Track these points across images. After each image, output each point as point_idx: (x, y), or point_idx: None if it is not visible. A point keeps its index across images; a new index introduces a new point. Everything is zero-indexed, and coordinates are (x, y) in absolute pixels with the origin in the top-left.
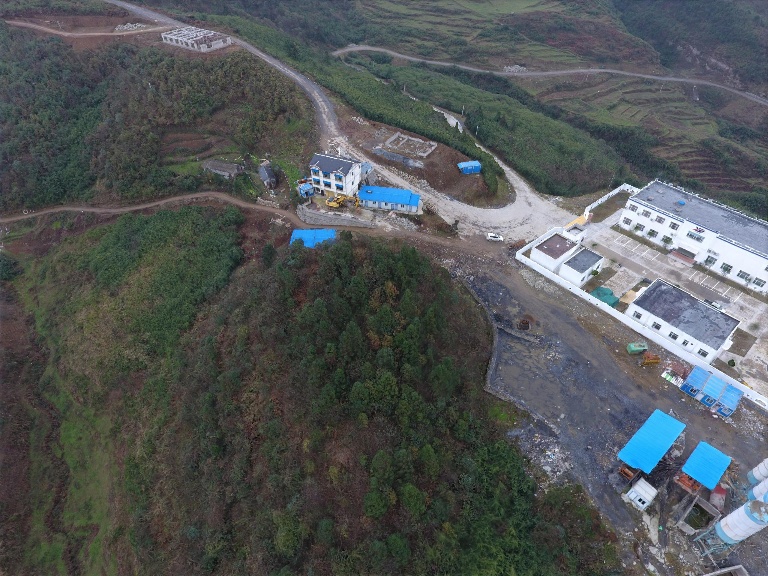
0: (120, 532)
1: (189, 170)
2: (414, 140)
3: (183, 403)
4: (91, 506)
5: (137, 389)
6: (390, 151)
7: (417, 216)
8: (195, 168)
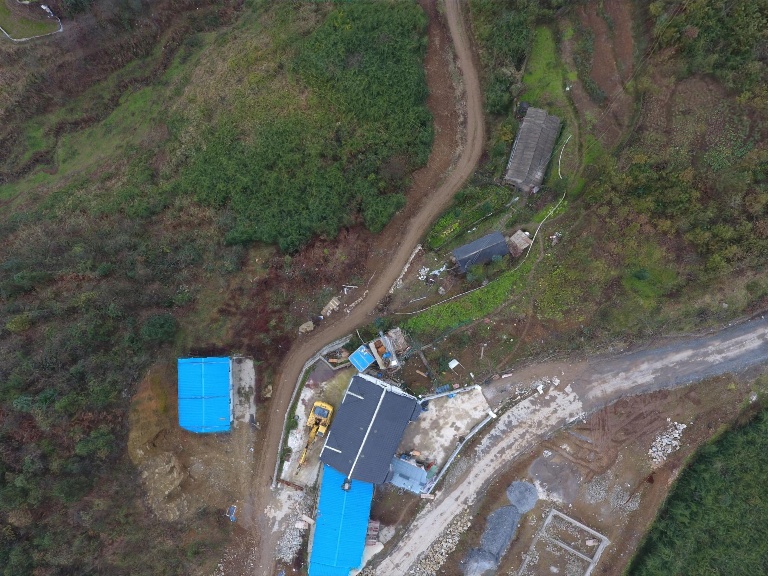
0: (32, 200)
1: (540, 81)
2: (585, 575)
3: (54, 242)
4: (74, 157)
5: (156, 159)
6: (528, 519)
7: (305, 567)
8: (545, 92)
